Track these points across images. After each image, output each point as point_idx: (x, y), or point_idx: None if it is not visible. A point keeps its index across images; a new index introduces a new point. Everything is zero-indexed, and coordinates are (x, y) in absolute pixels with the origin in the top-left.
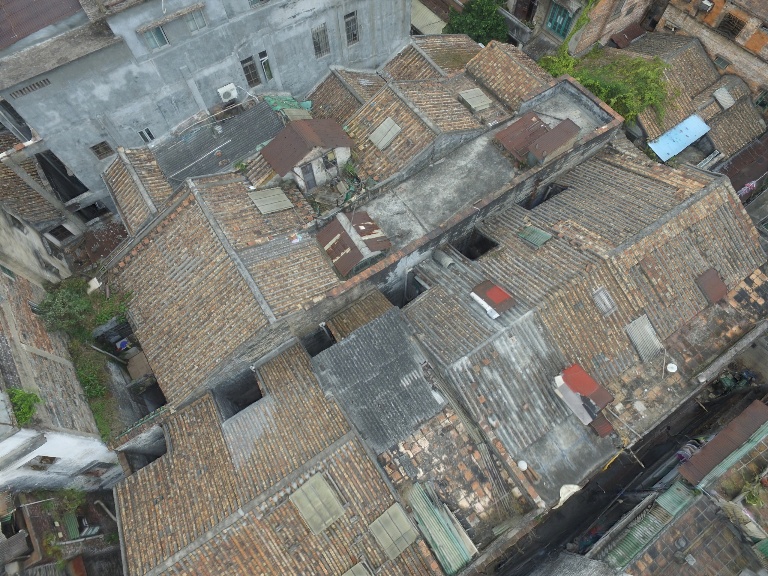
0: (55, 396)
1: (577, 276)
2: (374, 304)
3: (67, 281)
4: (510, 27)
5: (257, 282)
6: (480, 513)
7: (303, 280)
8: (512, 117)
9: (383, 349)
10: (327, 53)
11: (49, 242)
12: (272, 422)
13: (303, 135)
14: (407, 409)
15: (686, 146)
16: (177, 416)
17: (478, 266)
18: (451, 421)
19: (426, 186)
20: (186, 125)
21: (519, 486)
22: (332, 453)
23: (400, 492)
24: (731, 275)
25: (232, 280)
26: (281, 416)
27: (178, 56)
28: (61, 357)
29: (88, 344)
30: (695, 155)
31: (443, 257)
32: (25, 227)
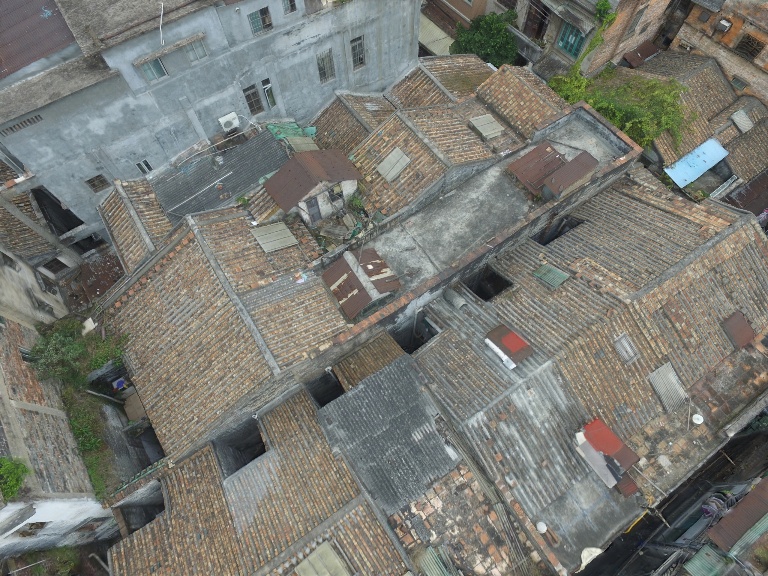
0: (46, 456)
1: (597, 322)
2: (383, 348)
3: (61, 322)
4: (520, 45)
5: (260, 329)
6: None
7: (308, 325)
8: (525, 146)
9: (393, 400)
10: (332, 78)
11: (43, 276)
12: (276, 481)
13: (308, 169)
14: (419, 465)
15: (704, 172)
16: (176, 470)
17: (492, 308)
18: (465, 479)
19: (436, 220)
20: (186, 155)
21: (538, 550)
22: (340, 519)
23: (412, 557)
24: (758, 318)
25: (234, 326)
26: (286, 474)
27: (177, 87)
28: (53, 408)
29: (82, 389)
30: (712, 179)
31: (455, 297)
32: (17, 264)
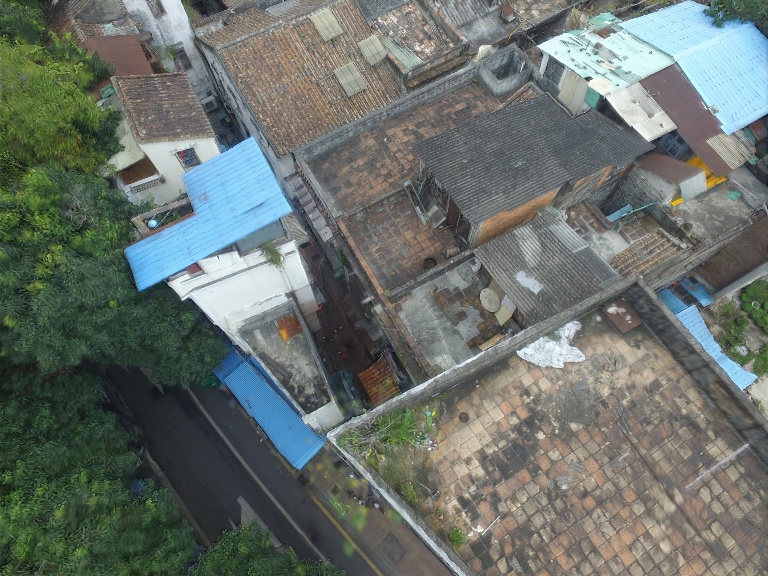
0: None
1: None
2: None
3: None
4: None
5: None
6: (428, 53)
7: None
8: None
9: None
10: None
11: None
12: (298, 4)
13: None
14: (384, 3)
15: None
16: (235, 17)
17: None
18: (412, 9)
19: None
20: None
21: (453, 40)
22: (336, 1)
23: None
24: None
25: None
26: None
27: None
28: None
29: None
30: None
31: None
32: None
